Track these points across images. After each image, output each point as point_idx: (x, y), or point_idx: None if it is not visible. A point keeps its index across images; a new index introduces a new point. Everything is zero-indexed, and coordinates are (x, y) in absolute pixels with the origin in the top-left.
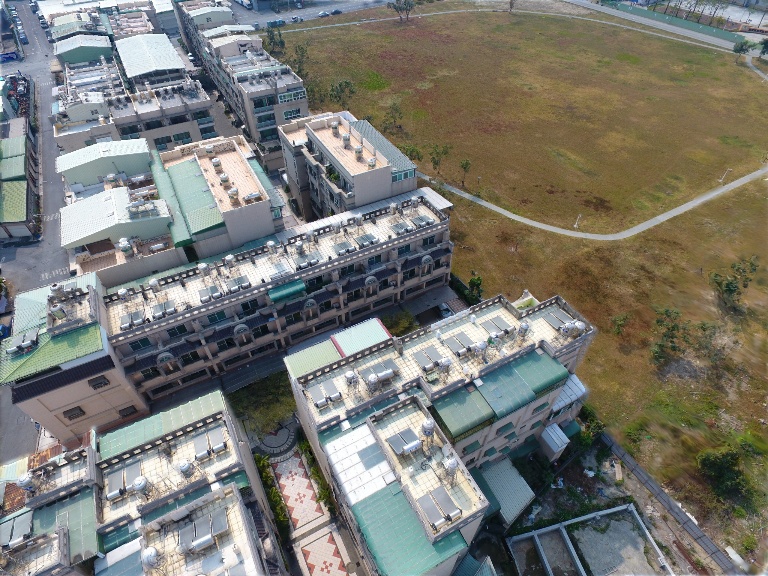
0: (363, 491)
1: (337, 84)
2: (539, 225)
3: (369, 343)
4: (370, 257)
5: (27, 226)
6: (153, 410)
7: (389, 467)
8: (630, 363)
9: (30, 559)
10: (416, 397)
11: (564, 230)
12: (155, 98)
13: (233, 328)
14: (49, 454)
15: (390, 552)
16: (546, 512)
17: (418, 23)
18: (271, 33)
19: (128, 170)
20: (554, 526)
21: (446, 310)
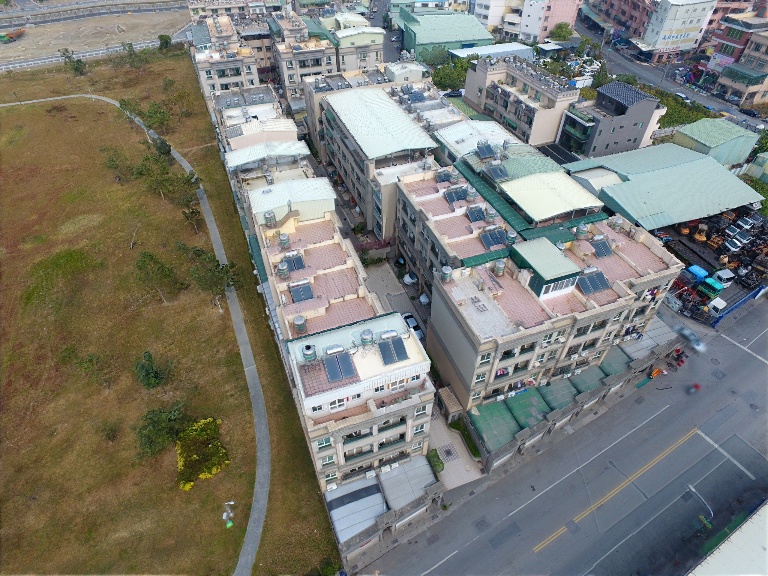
0: None
1: (121, 272)
2: (114, 102)
3: None
4: None
5: None
6: None
7: None
8: None
9: None
10: None
11: (104, 99)
12: None
13: None
14: None
15: None
16: None
17: None
18: None
19: None
20: None
21: None
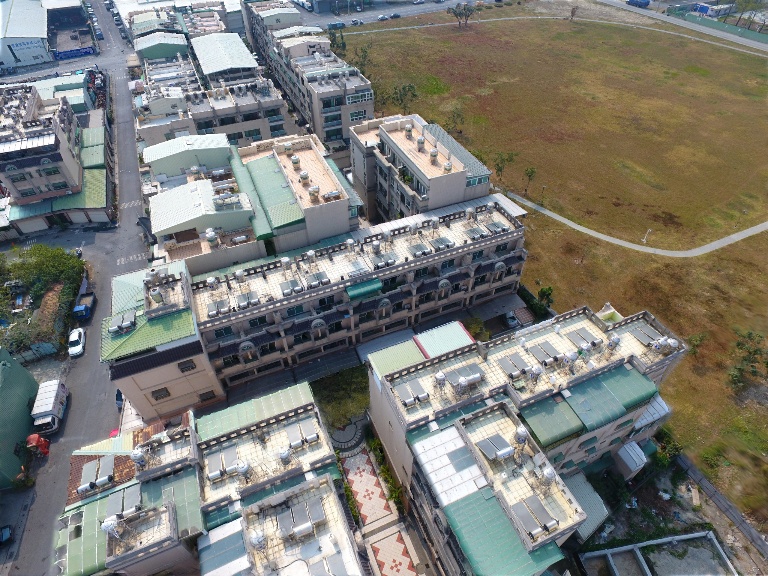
0: (455, 493)
1: (397, 87)
2: (605, 238)
3: (452, 346)
4: (445, 260)
5: (106, 212)
6: (229, 396)
7: (480, 471)
8: (705, 385)
9: (141, 529)
10: (505, 403)
11: (632, 244)
12: (229, 95)
13: (311, 322)
14: (152, 431)
15: (485, 557)
16: (619, 532)
17: (477, 29)
18: (333, 35)
19: (209, 163)
20: (627, 547)
21: (512, 318)
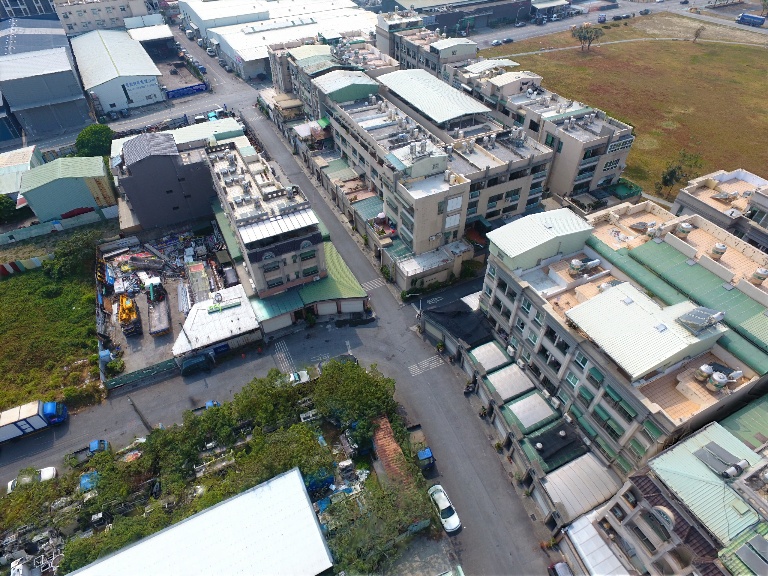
0: None
1: None
2: None
3: None
4: None
5: (364, 301)
6: None
7: None
8: None
9: None
10: None
11: None
12: (476, 147)
13: None
14: None
15: None
16: None
17: (602, 53)
18: None
19: (565, 250)
20: None
21: None
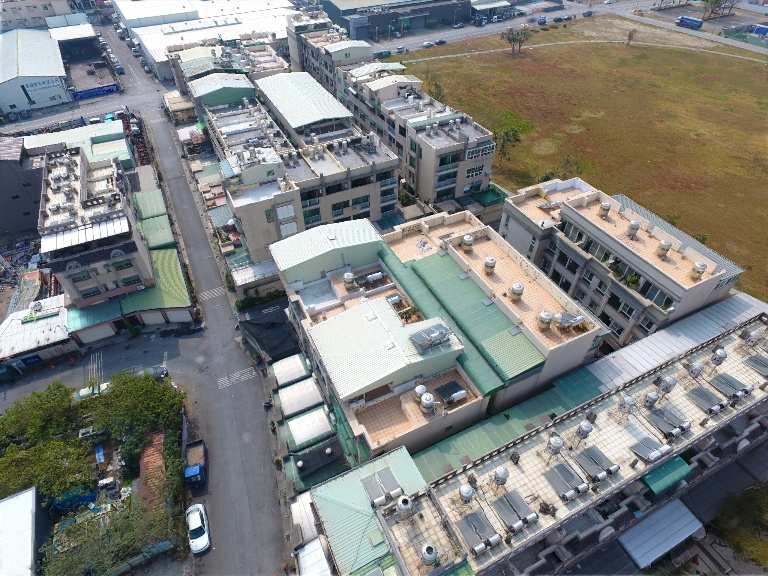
0: None
1: None
2: None
3: None
4: (744, 413)
5: (190, 311)
6: None
7: None
8: None
9: None
10: None
11: None
12: (327, 153)
13: (598, 533)
14: None
15: None
16: None
17: (532, 55)
18: None
19: (354, 262)
20: None
21: None
